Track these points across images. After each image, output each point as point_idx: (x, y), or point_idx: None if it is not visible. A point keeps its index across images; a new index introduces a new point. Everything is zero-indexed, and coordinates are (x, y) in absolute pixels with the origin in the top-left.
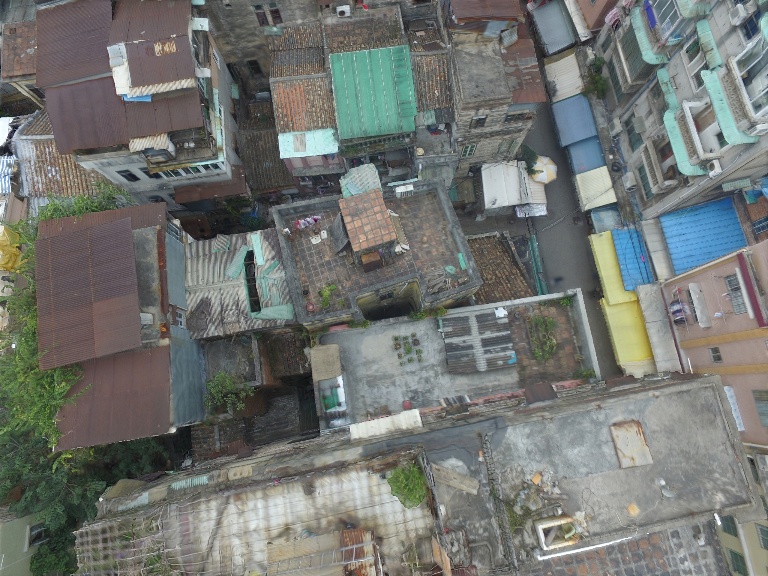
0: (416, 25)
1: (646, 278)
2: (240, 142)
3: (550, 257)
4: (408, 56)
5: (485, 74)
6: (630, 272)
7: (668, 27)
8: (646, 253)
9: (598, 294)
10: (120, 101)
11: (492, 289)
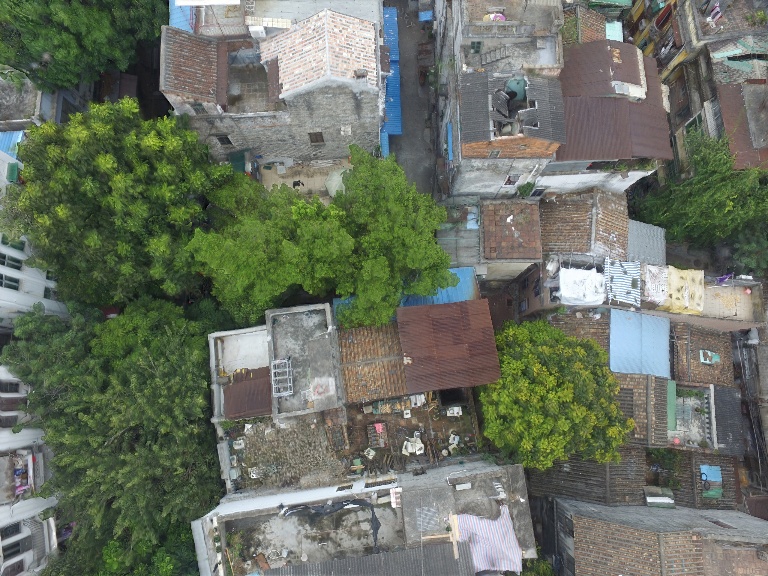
0: None
1: None
2: None
3: None
4: None
5: None
6: None
7: None
8: None
9: None
10: (641, 105)
11: None
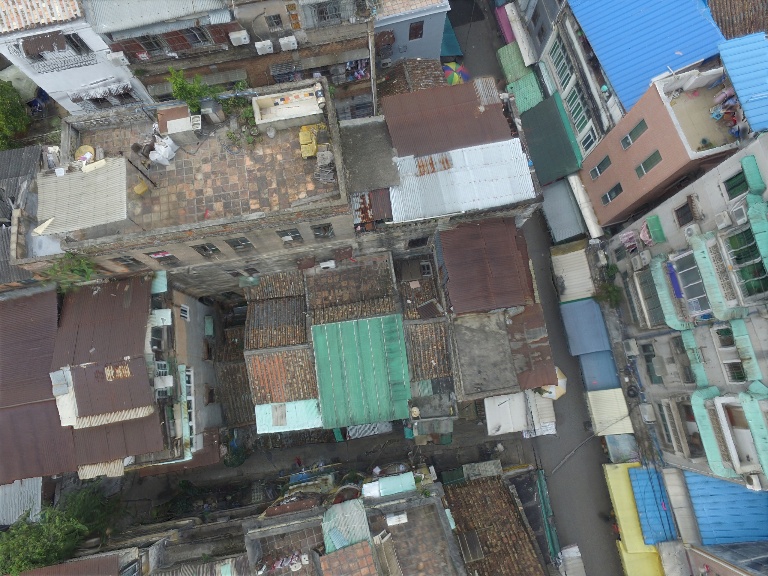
0: (410, 273)
1: (668, 530)
2: (215, 377)
3: (559, 471)
4: (401, 327)
5: (488, 355)
6: (650, 522)
7: (696, 307)
8: (668, 500)
9: (613, 518)
10: None
11: (497, 562)
